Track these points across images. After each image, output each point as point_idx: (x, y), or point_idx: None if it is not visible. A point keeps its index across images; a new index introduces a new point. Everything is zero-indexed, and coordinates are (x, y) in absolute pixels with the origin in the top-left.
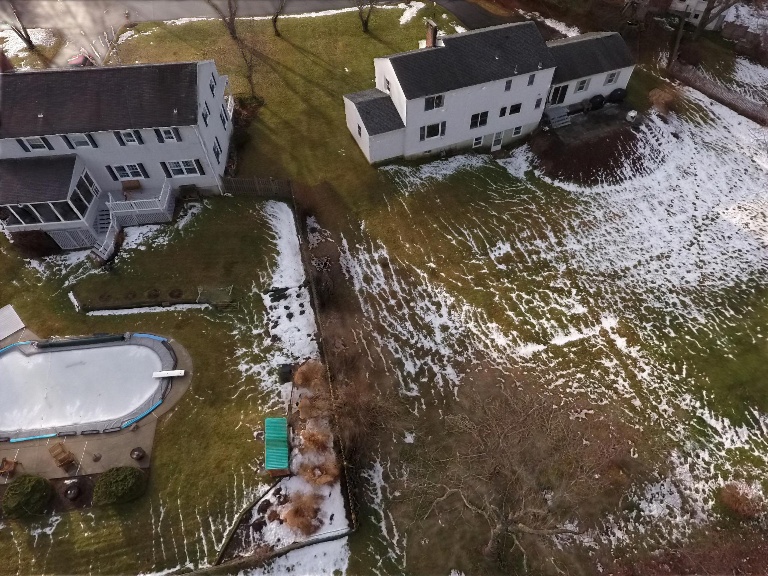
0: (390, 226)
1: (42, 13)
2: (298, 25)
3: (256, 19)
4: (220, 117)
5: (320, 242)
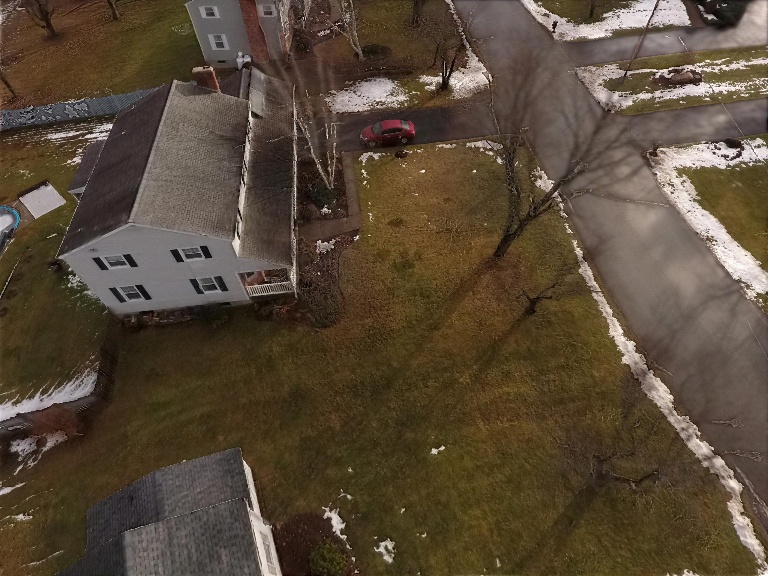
0: (0, 566)
1: (529, 70)
2: (575, 338)
3: (582, 270)
4: (191, 280)
5: (18, 454)
